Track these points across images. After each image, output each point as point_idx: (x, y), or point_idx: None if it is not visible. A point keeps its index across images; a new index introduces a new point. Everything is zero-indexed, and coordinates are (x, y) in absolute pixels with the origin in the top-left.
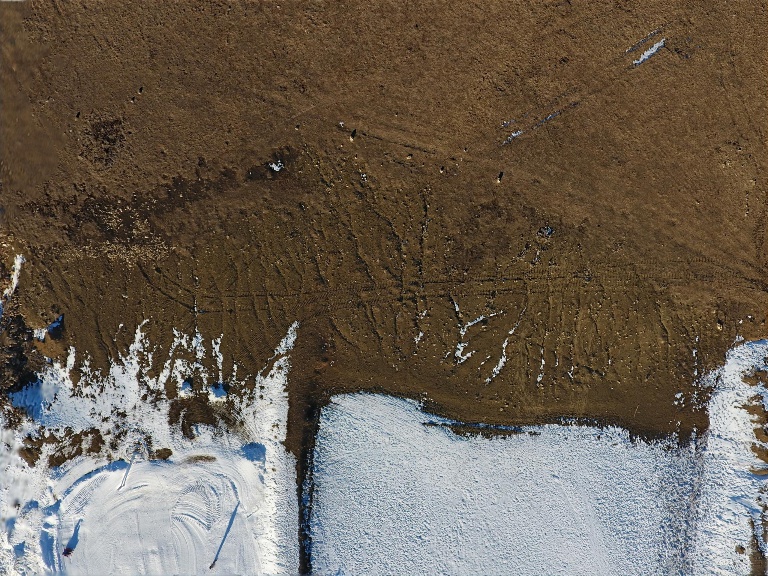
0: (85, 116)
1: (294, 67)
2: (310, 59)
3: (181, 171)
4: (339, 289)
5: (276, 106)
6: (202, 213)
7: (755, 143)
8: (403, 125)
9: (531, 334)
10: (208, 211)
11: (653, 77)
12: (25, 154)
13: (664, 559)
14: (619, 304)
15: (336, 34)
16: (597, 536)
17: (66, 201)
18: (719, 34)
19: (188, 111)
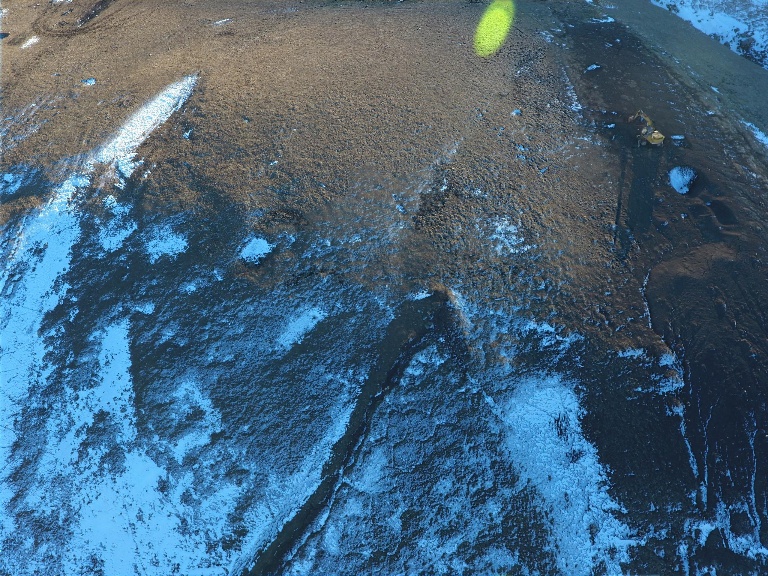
0: (487, 4)
1: None
2: None
3: None
4: None
5: None
6: None
7: None
8: None
9: None
10: None
11: None
12: None
13: None
14: None
15: None
16: None
17: None
18: None
19: (441, 4)
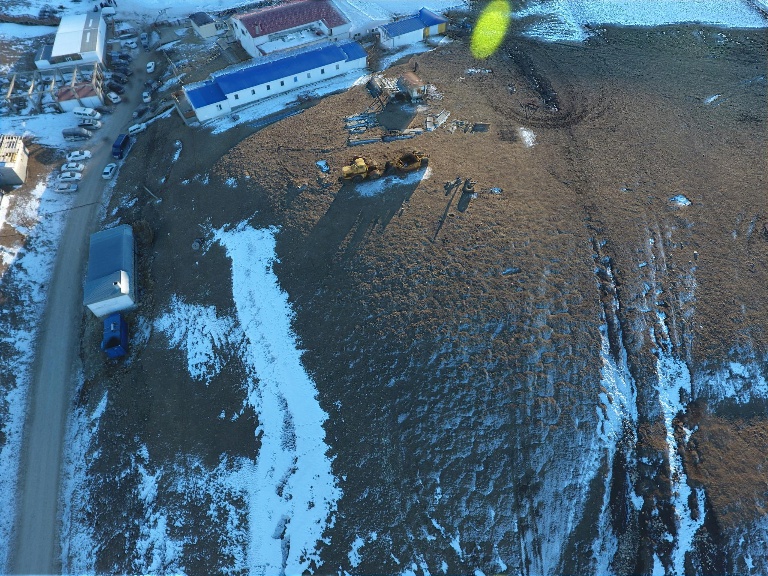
0: None
1: None
2: None
3: None
4: None
5: None
6: None
7: None
8: None
9: None
10: None
11: None
12: None
13: (587, 1)
14: None
15: None
16: (620, 4)
17: None
18: None
19: None
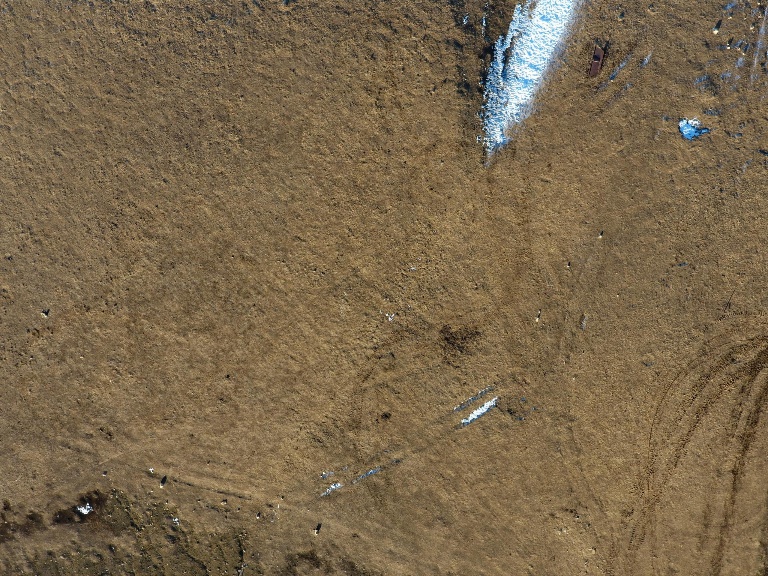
0: None
1: (100, 416)
2: (116, 408)
3: None
4: None
5: (82, 453)
6: (9, 554)
7: (595, 512)
8: (216, 472)
9: None
10: (15, 552)
11: (482, 438)
12: None
13: None
14: None
15: (143, 384)
16: None
17: None
18: (556, 397)
19: None
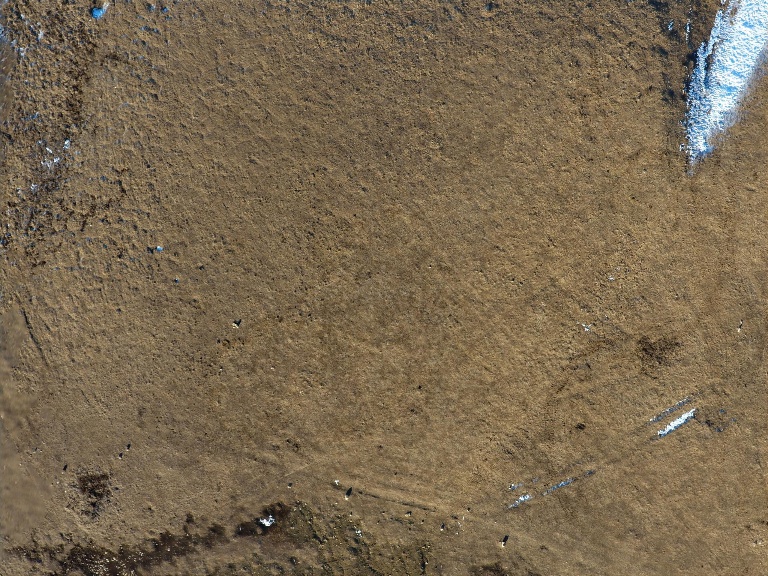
0: (72, 469)
1: (288, 427)
2: (305, 419)
3: (169, 527)
4: None
5: (268, 465)
6: (190, 567)
7: None
8: (402, 484)
9: None
10: (196, 565)
11: (679, 450)
12: (12, 501)
13: None
14: None
15: (333, 395)
16: None
17: (53, 549)
18: (757, 408)
19: (176, 470)
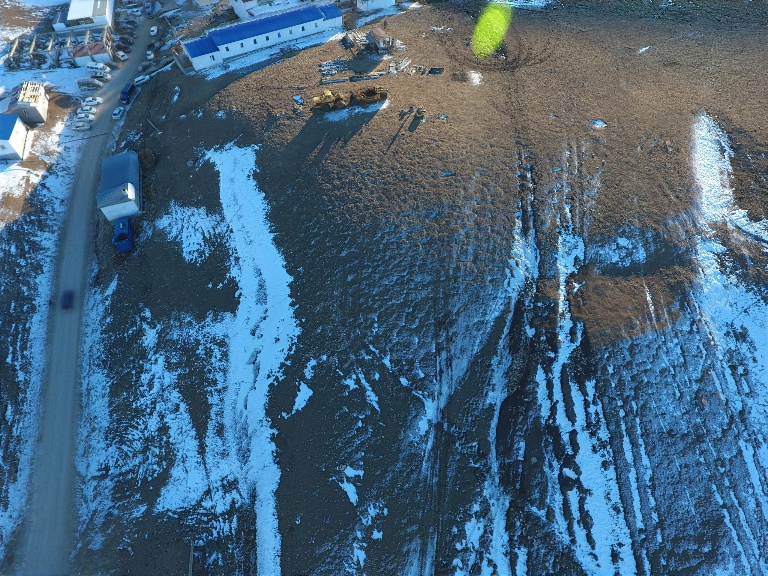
0: None
1: None
2: None
3: None
4: (740, 6)
5: None
6: None
7: None
8: None
9: (642, 2)
10: None
11: None
12: None
13: None
14: (608, 7)
15: None
16: None
17: None
18: None
19: None
